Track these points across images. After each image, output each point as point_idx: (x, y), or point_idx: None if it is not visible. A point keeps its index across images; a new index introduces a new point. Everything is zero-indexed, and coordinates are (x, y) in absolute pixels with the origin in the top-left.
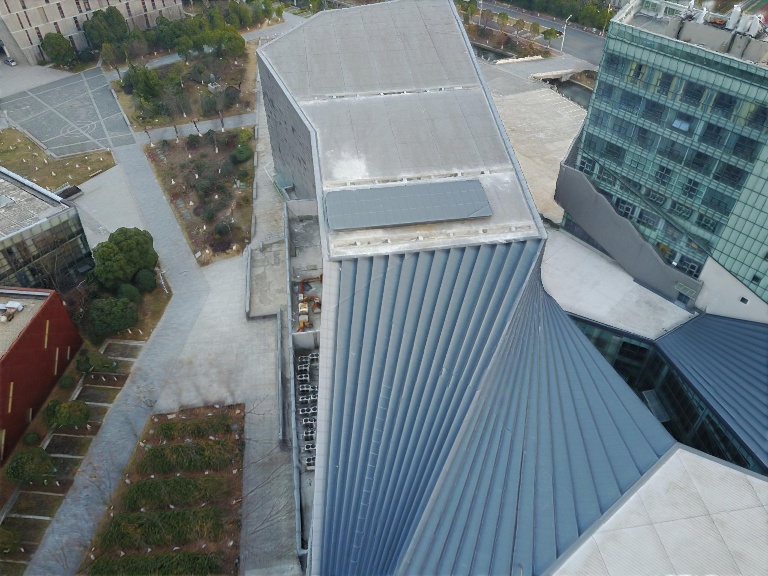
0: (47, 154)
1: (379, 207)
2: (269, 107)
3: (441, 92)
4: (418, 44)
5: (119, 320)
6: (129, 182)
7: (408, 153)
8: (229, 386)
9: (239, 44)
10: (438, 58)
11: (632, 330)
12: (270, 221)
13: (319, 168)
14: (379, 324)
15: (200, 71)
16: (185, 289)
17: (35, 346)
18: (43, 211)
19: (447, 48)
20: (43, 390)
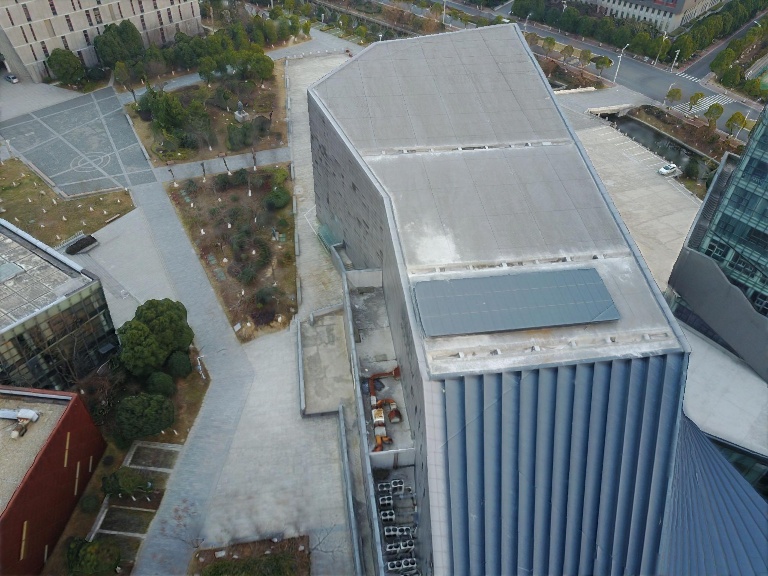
0: (56, 192)
1: (482, 305)
2: (319, 153)
3: (528, 148)
4: (492, 86)
5: (153, 424)
6: (151, 230)
7: (503, 229)
8: (287, 510)
9: (268, 67)
10: (518, 104)
11: None
12: (317, 284)
13: (400, 247)
14: (502, 473)
15: (226, 97)
16: (225, 373)
17: (53, 468)
18: (60, 284)
19: (526, 92)
20: (61, 518)
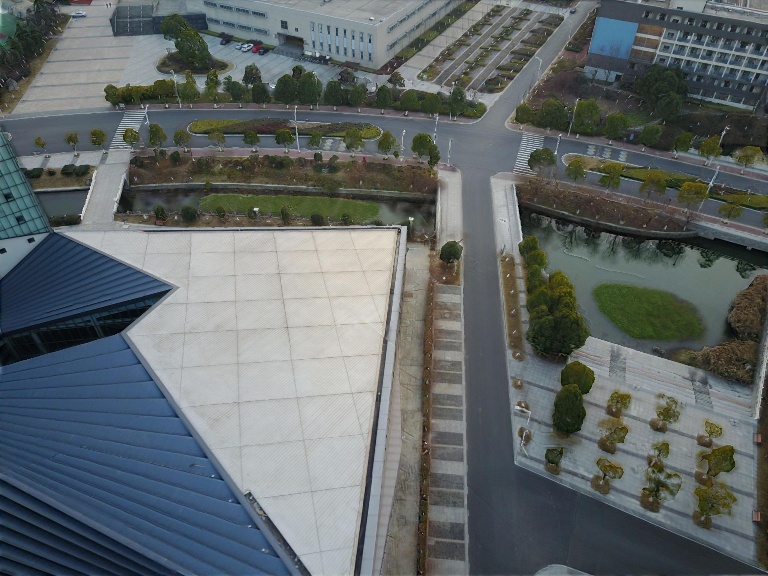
0: None
1: None
2: None
3: None
4: None
5: None
6: None
7: None
8: None
9: None
10: None
11: None
12: None
13: None
14: None
15: None
16: None
17: None
18: None
19: None
20: None
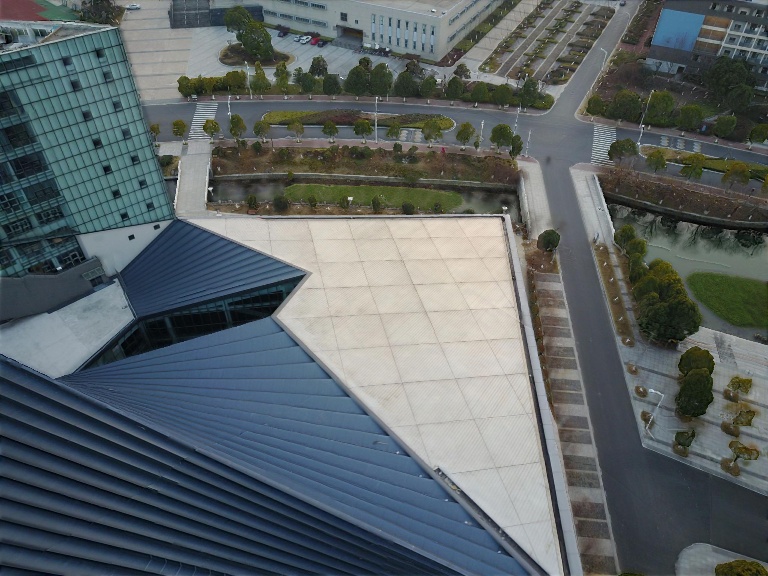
0: None
1: None
2: None
3: None
4: None
5: None
6: None
7: None
8: None
9: None
10: None
11: (115, 331)
12: None
13: None
14: (40, 571)
15: None
16: None
17: None
18: None
19: None
20: None
